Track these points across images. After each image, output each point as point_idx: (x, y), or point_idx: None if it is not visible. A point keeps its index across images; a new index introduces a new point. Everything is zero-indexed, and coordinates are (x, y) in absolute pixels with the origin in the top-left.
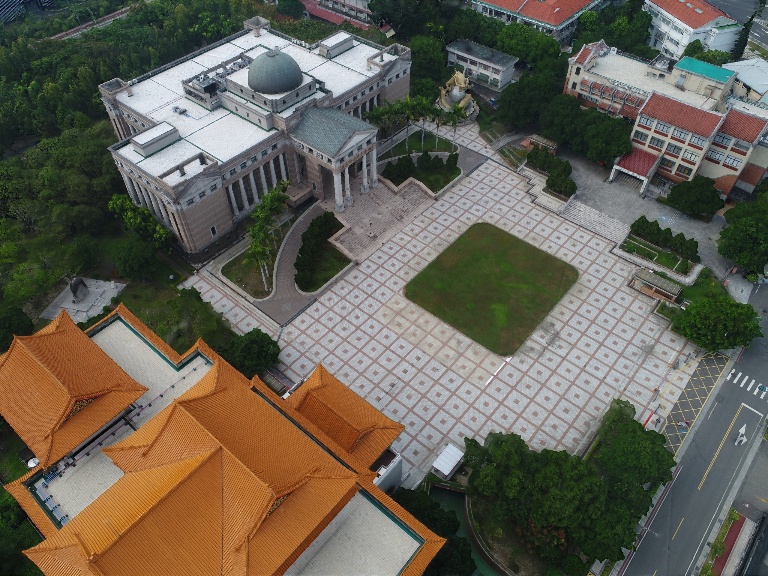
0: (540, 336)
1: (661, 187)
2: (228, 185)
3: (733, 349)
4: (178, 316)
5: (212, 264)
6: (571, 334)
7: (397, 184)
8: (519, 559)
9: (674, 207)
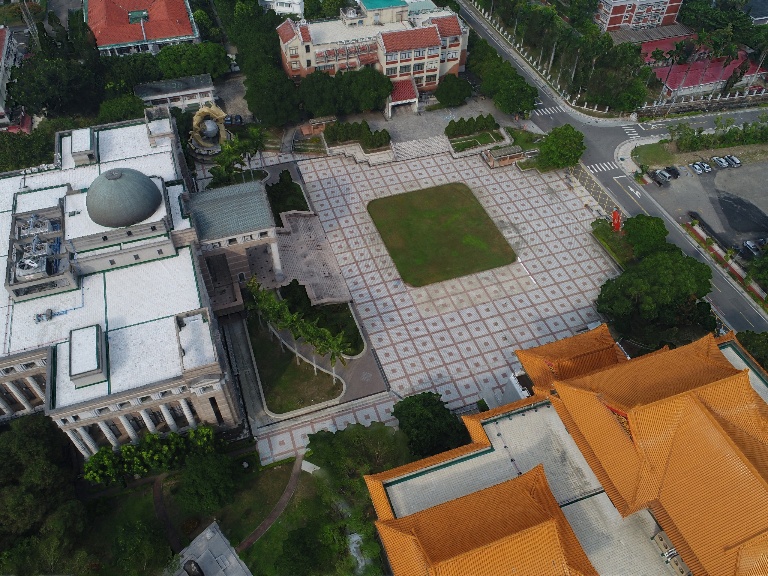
0: (508, 233)
1: (421, 101)
2: None
3: None
4: (351, 459)
5: (254, 419)
6: (516, 217)
7: (280, 226)
8: (682, 337)
9: (441, 108)
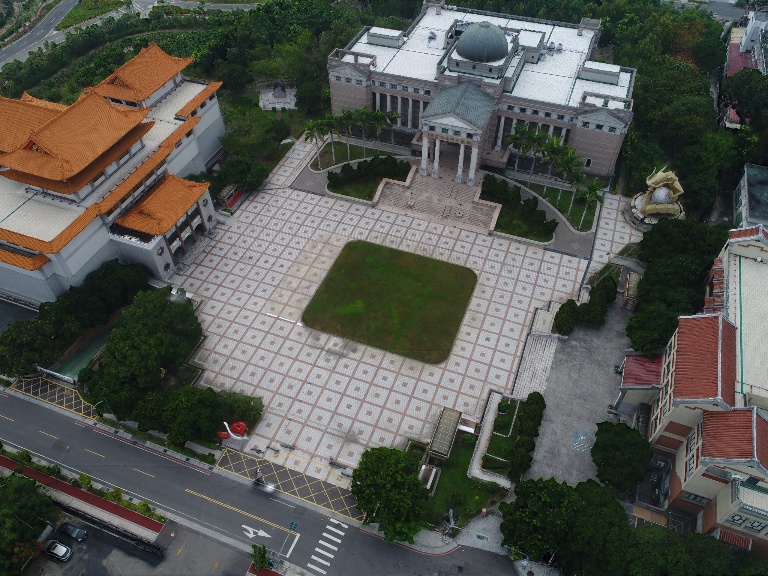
0: (336, 343)
1: None
2: (376, 91)
3: (378, 525)
4: None
5: (337, 136)
6: (347, 367)
7: (485, 198)
8: None
9: None
